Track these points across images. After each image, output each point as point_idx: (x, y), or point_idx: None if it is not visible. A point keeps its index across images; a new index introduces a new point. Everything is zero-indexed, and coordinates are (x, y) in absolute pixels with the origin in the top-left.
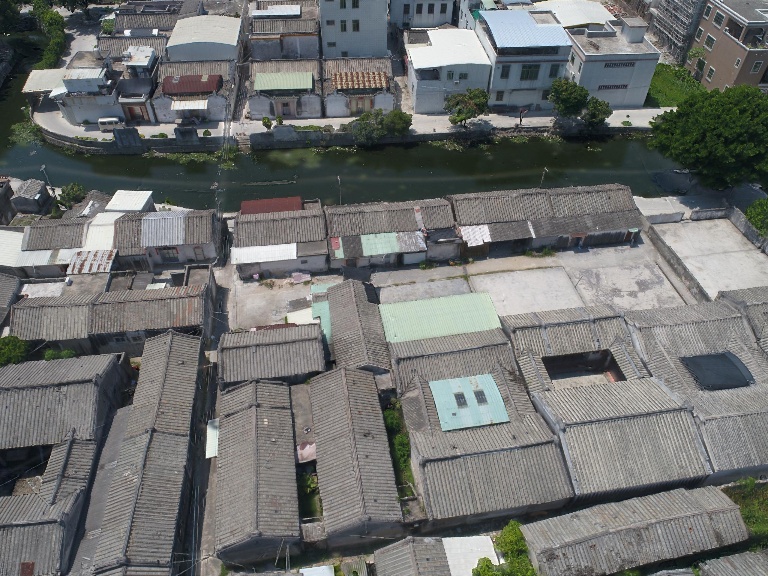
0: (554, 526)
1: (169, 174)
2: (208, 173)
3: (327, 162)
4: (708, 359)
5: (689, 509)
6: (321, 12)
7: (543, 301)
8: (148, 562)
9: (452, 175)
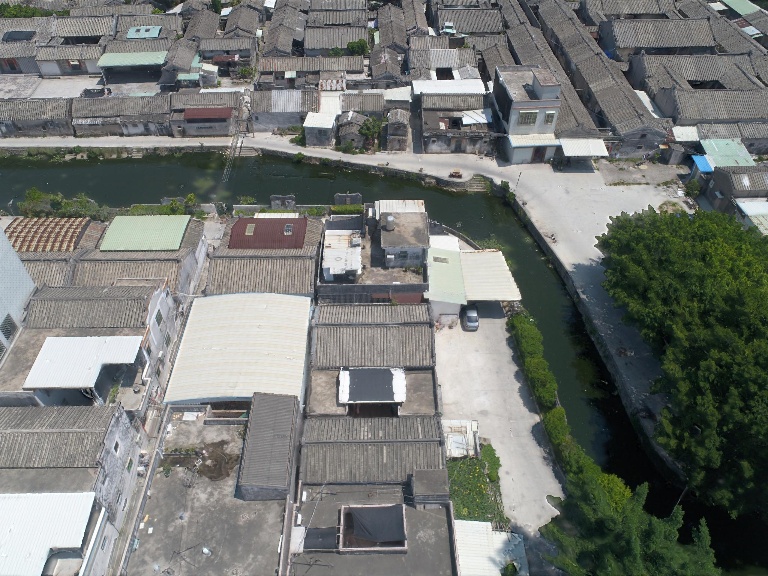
0: (139, 11)
1: (306, 196)
2: (267, 193)
3: (143, 200)
4: (18, 37)
5: (89, 8)
6: (23, 267)
7: (60, 89)
8: (279, 8)
9: (28, 185)
